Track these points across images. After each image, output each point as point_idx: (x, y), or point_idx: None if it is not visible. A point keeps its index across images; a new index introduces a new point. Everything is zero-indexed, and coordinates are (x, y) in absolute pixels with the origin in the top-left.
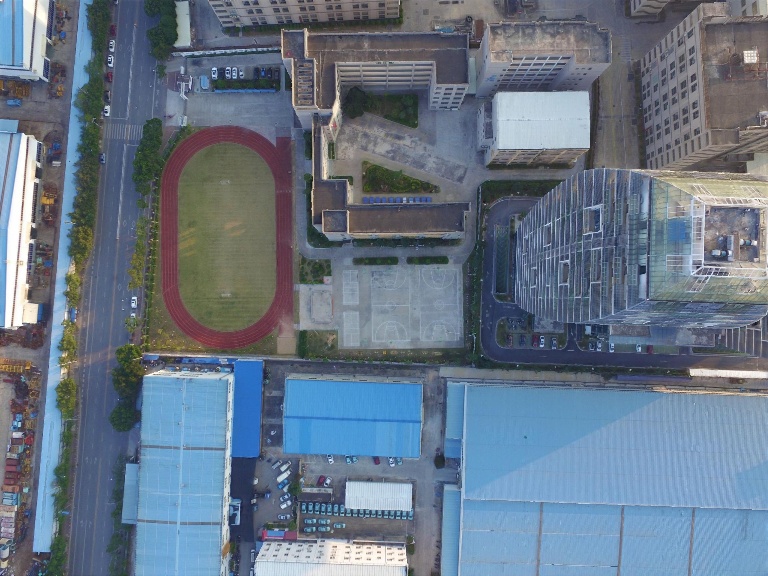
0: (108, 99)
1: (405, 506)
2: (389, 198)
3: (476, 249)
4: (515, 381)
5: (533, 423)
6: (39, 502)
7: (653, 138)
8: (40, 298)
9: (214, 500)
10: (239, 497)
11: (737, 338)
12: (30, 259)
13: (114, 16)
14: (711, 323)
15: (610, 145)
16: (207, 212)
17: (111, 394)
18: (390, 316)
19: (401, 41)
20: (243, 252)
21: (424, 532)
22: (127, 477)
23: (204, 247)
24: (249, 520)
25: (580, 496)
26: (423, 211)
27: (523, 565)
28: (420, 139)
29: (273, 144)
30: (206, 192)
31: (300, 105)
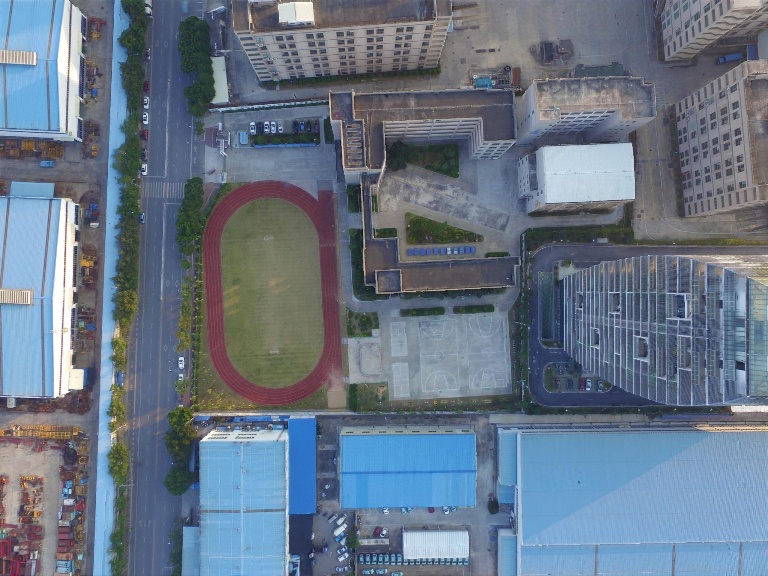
0: (145, 157)
1: (462, 553)
2: (434, 249)
3: (521, 296)
4: (563, 424)
5: (586, 468)
6: (95, 569)
7: (691, 183)
8: (84, 362)
9: (276, 561)
10: (297, 553)
11: None
12: (73, 324)
13: (147, 72)
14: None
15: (648, 189)
16: (251, 269)
17: (162, 456)
18: (439, 366)
19: (447, 98)
20: (289, 308)
21: (480, 575)
22: (185, 540)
23: (250, 304)
24: (308, 575)
25: (633, 537)
26: (474, 266)
27: None
28: (462, 189)
29: (315, 198)
30: (249, 249)
31: (350, 167)
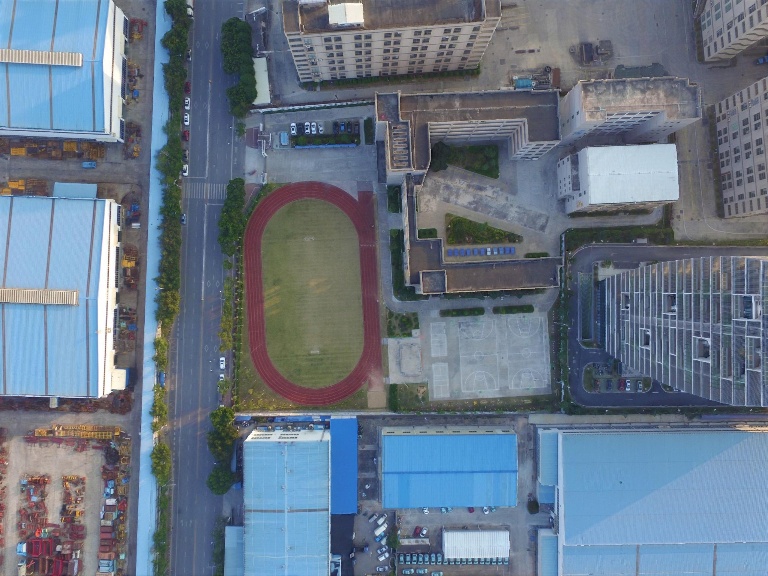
0: (186, 158)
1: (503, 553)
2: (473, 249)
3: (561, 297)
4: (602, 424)
5: (627, 468)
6: (138, 569)
7: (732, 184)
8: (126, 363)
9: (320, 560)
10: (339, 553)
11: None
12: (115, 324)
13: (188, 73)
14: None
15: (687, 190)
16: (292, 269)
17: (203, 456)
18: (478, 366)
19: (492, 99)
20: (330, 308)
21: (519, 575)
22: (227, 540)
23: (290, 305)
24: (350, 575)
25: (675, 537)
26: (517, 267)
27: None
28: (502, 189)
29: (355, 199)
30: (290, 249)
31: (396, 168)
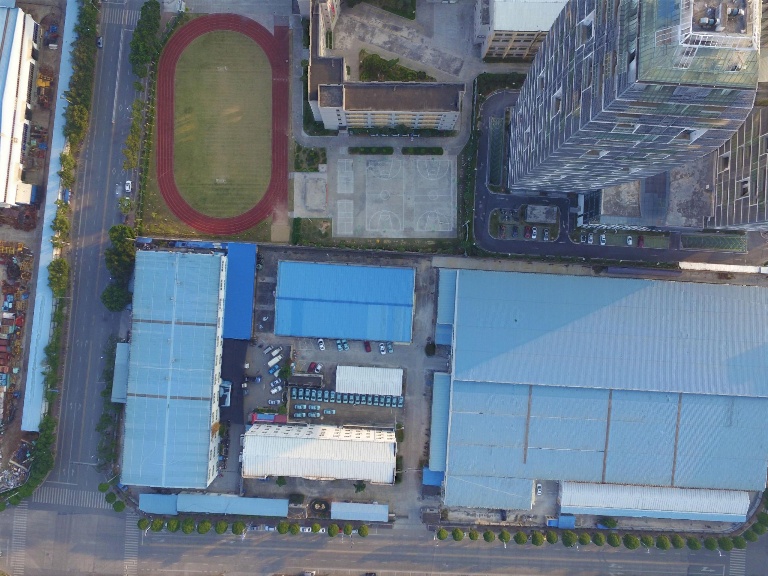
0: None
1: (395, 391)
2: None
3: (471, 140)
4: None
5: (524, 307)
6: (28, 381)
7: None
8: (34, 180)
9: (205, 375)
10: (230, 379)
11: (726, 213)
12: (24, 140)
13: None
14: (699, 134)
15: None
16: (203, 98)
17: (103, 277)
18: (384, 205)
19: None
20: (239, 139)
21: (413, 420)
22: (118, 356)
23: (200, 133)
24: (239, 402)
25: (569, 379)
26: (419, 91)
27: (511, 448)
28: (417, 31)
29: (271, 33)
30: (203, 79)
31: None
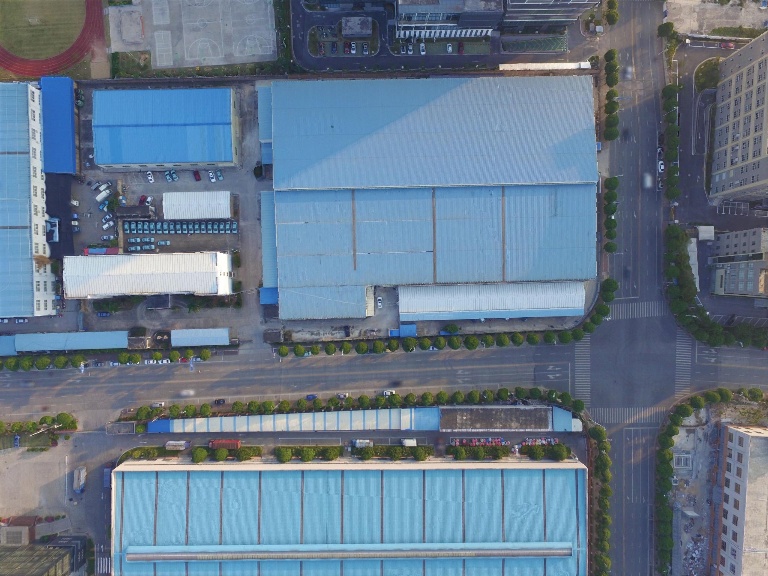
0: None
1: (223, 212)
2: None
3: None
4: None
5: (339, 113)
6: None
7: None
8: None
9: (21, 204)
10: (57, 216)
11: None
12: None
13: None
14: None
15: None
16: None
17: None
18: (202, 33)
19: None
20: None
21: (250, 245)
22: None
23: None
24: (69, 238)
25: (388, 179)
26: None
27: (340, 256)
28: None
29: None
30: None
31: None
